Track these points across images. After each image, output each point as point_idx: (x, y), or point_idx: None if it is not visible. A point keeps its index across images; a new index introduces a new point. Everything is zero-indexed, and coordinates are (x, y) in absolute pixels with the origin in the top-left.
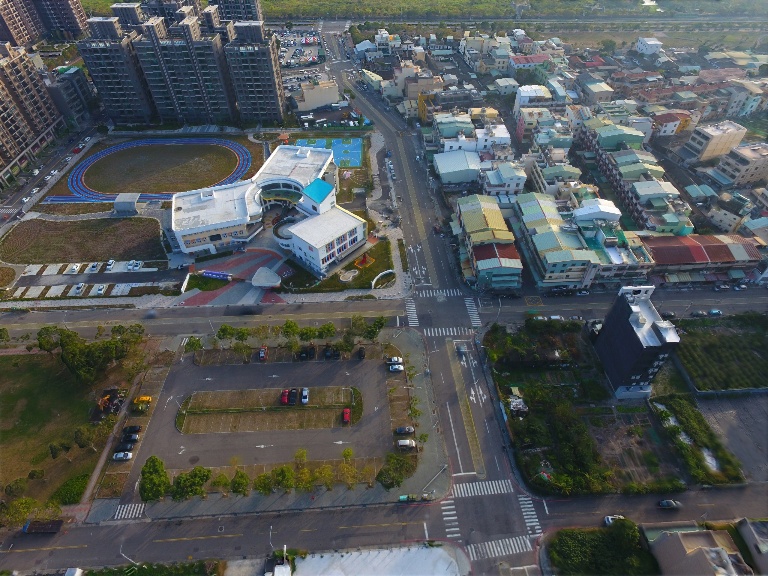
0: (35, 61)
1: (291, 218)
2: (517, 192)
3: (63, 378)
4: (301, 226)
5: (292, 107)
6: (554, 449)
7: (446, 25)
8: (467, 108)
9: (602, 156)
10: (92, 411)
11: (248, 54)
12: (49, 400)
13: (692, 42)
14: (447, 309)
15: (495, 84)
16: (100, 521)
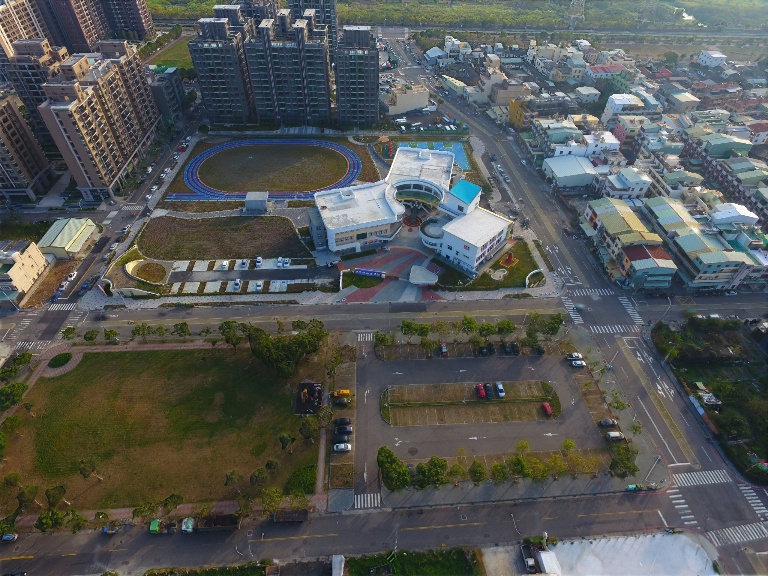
0: None
1: (432, 218)
2: (639, 196)
3: (253, 372)
4: (453, 226)
5: (382, 110)
6: (755, 441)
7: (506, 34)
8: (561, 115)
9: (712, 163)
10: (294, 404)
11: (357, 58)
12: (246, 393)
13: (746, 56)
14: (605, 307)
15: (575, 92)
16: (342, 510)
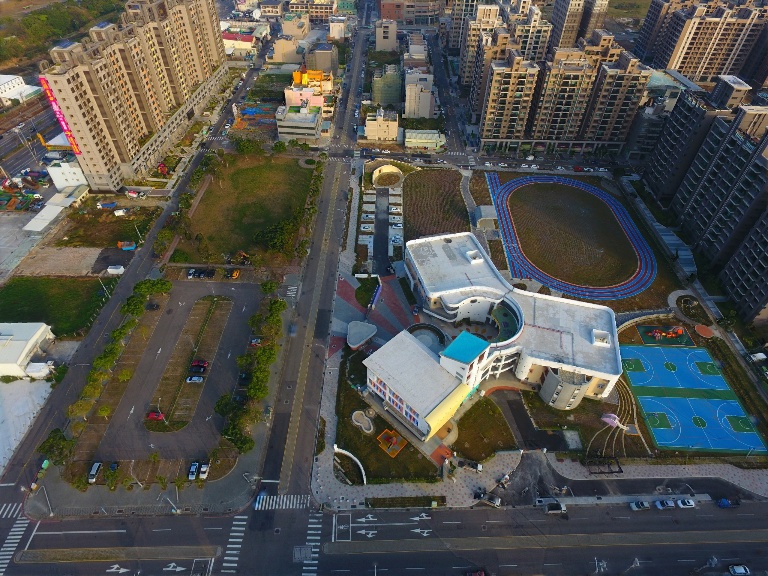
0: None
1: (450, 340)
2: None
3: None
4: (411, 343)
5: None
6: None
7: None
8: None
9: None
10: None
11: None
12: None
13: None
14: (275, 559)
15: None
16: (150, 274)
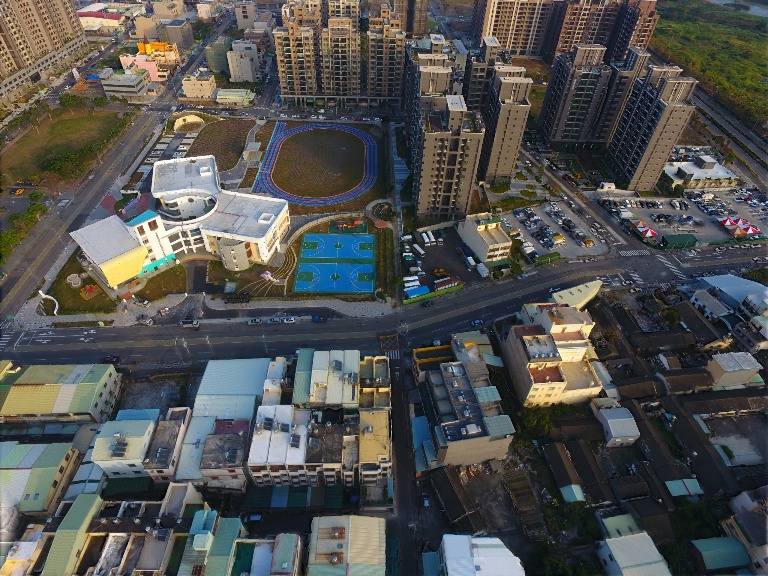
0: (460, 58)
1: None
2: None
3: None
4: (115, 223)
5: None
6: None
7: None
8: None
9: None
10: None
11: None
12: None
13: None
14: None
15: None
16: None
